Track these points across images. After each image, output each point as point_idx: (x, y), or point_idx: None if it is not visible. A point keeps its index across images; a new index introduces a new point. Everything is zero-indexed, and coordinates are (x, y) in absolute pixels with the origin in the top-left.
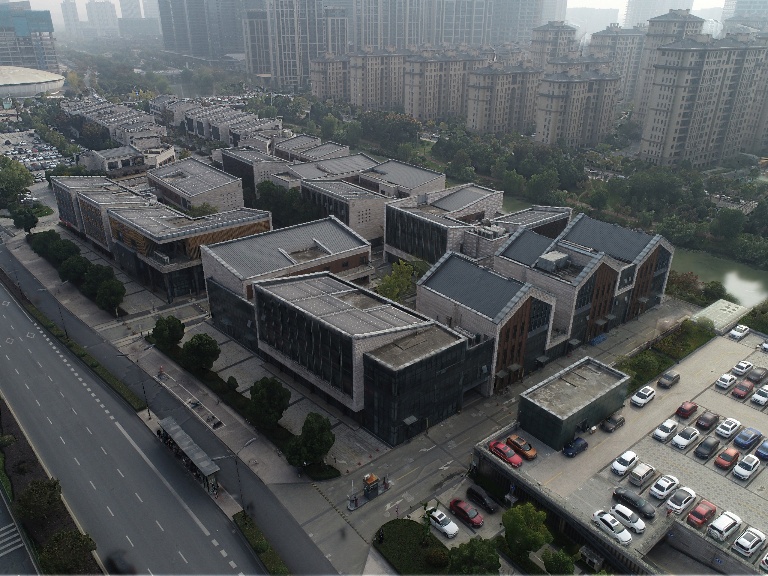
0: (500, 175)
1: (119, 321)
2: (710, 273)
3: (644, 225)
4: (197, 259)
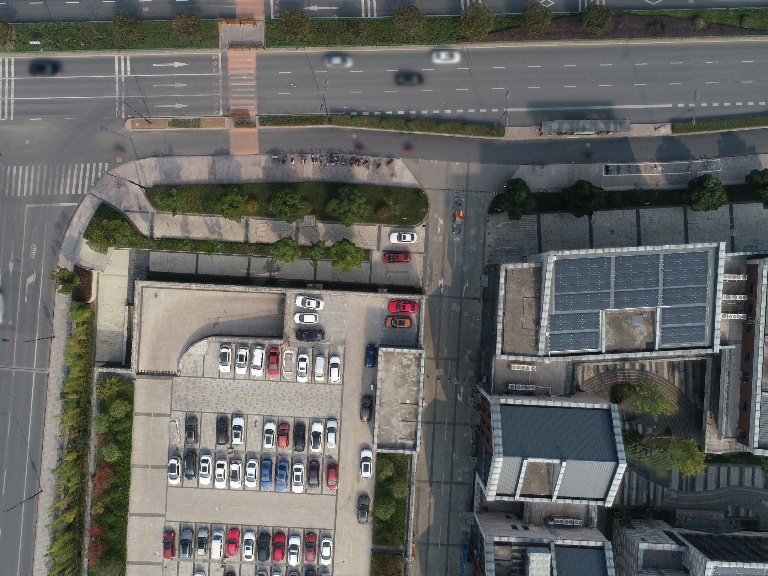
0: None
1: None
2: None
3: None
4: None
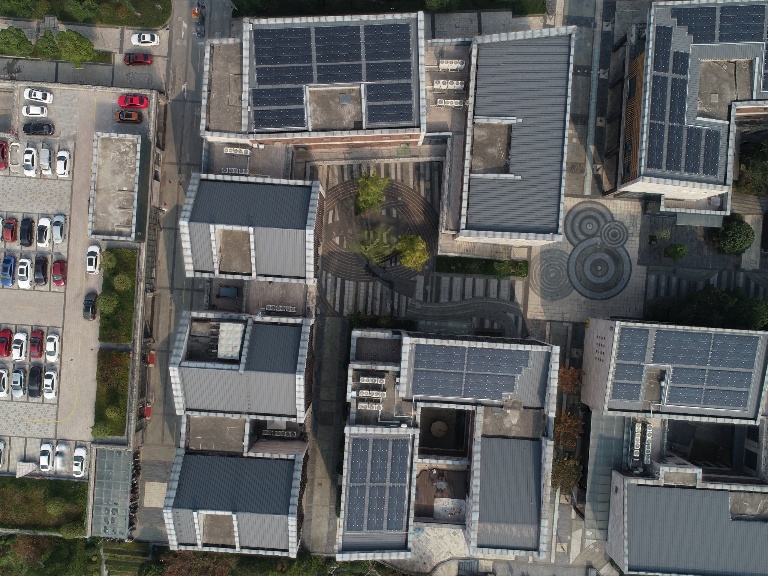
0: None
1: None
2: None
3: None
4: (629, 71)
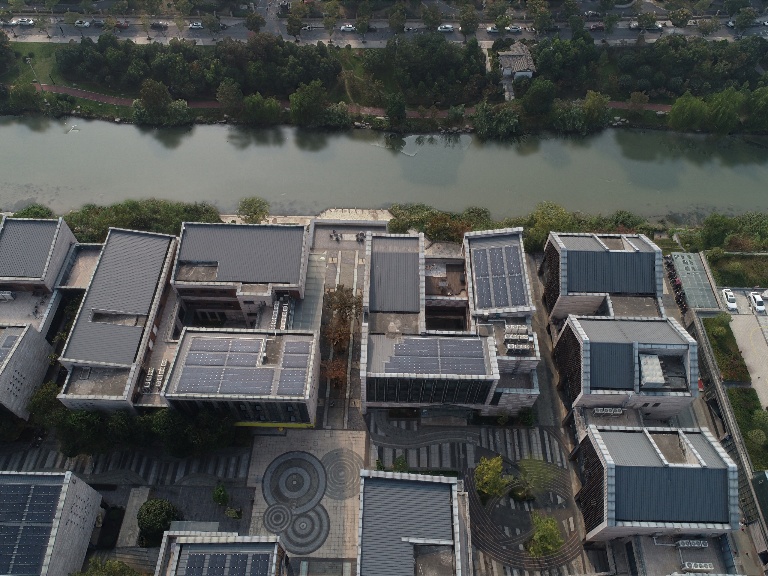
0: (238, 104)
1: None
2: (568, 173)
3: (457, 122)
4: None
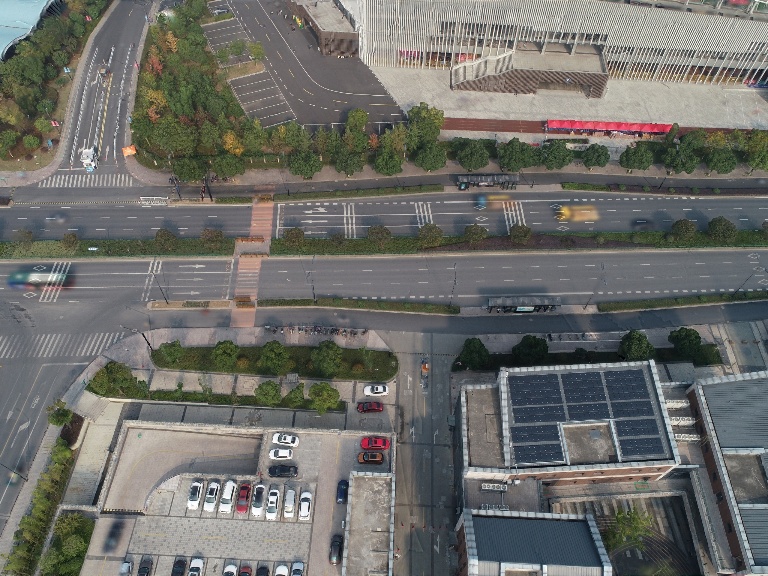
0: None
1: (765, 341)
2: None
3: None
4: None
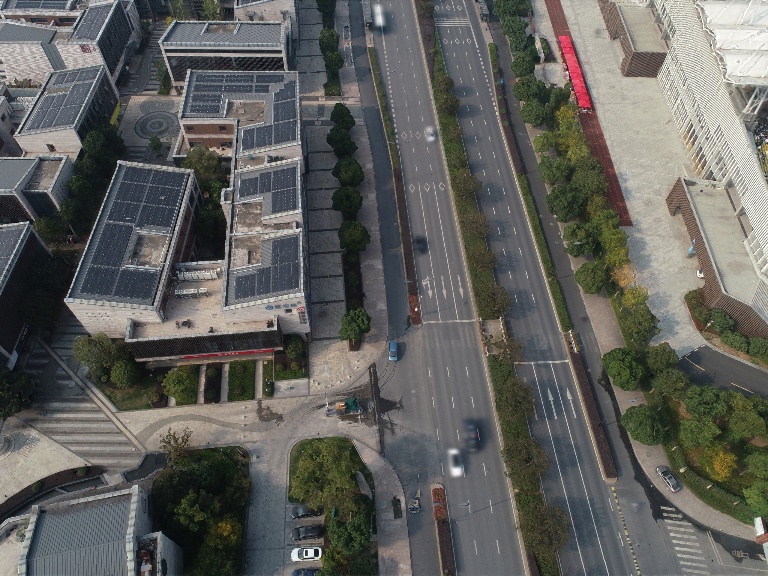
0: None
1: None
2: None
3: None
4: None
